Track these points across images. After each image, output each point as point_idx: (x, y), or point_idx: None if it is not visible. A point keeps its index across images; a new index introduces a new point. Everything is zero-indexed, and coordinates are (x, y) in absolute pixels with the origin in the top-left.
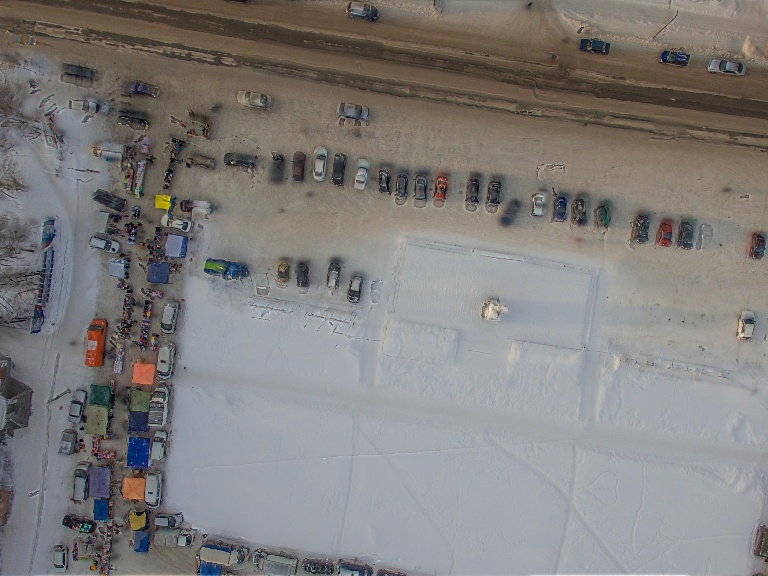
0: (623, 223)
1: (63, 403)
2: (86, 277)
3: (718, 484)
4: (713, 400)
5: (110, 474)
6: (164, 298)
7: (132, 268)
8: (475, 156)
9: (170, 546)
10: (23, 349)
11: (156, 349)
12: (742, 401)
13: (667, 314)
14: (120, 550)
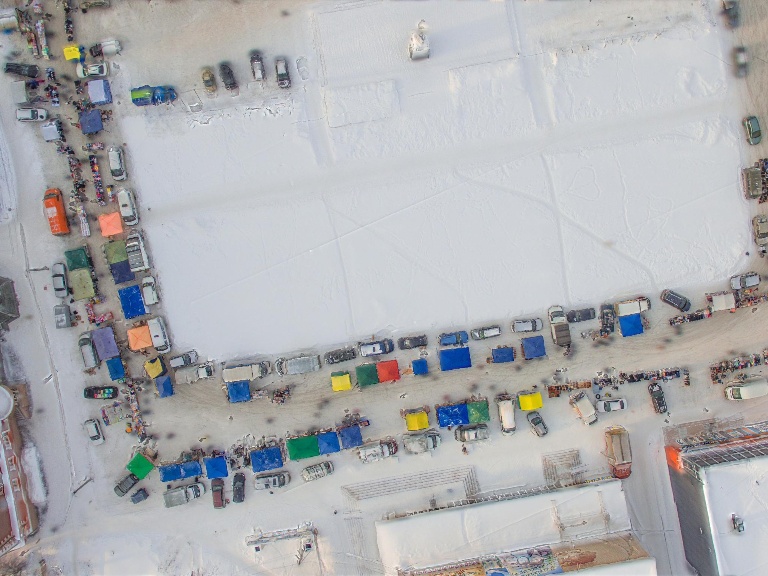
0: None
1: (46, 283)
2: (25, 154)
3: (690, 144)
4: (658, 64)
5: (112, 332)
6: (106, 148)
7: (66, 130)
8: None
9: None
10: None
11: (115, 199)
12: (685, 54)
13: None
14: (148, 406)
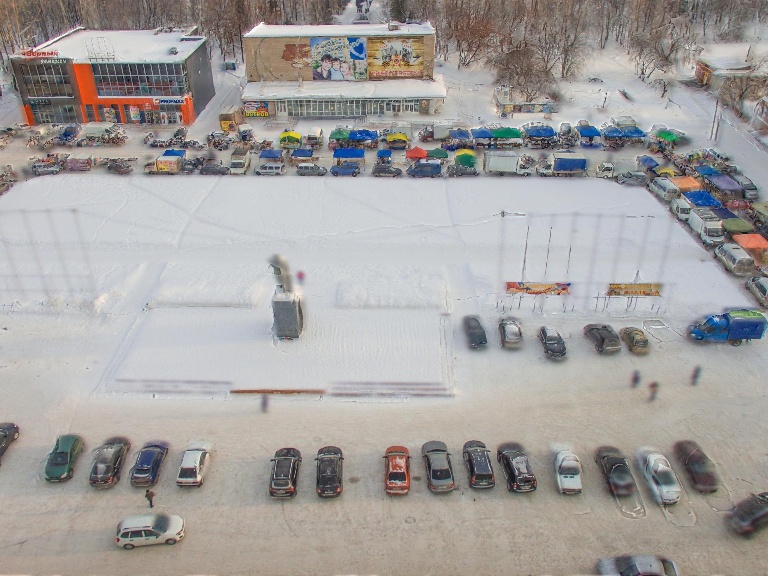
0: (18, 465)
1: None
2: None
3: None
4: None
5: None
6: None
7: None
8: (330, 547)
9: None
10: None
11: (757, 266)
12: None
13: None
14: None
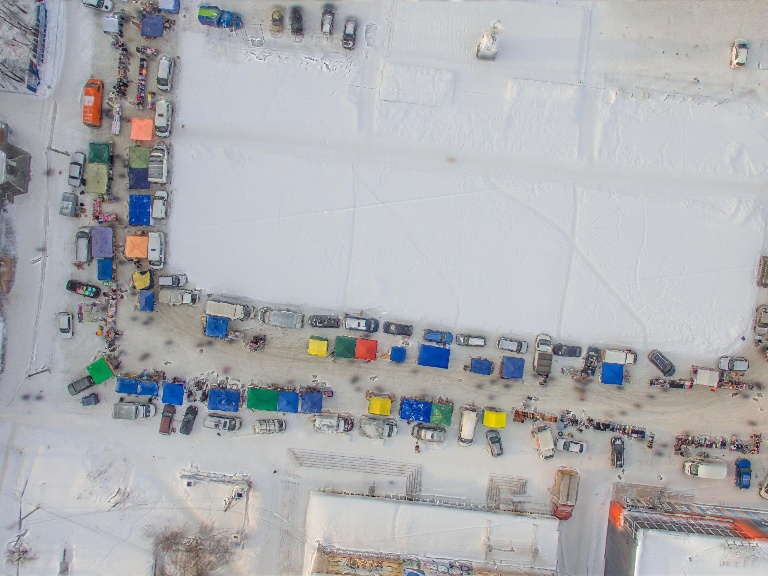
0: None
1: (62, 168)
2: (80, 38)
3: (719, 217)
4: (710, 132)
5: (112, 234)
6: (159, 55)
7: (126, 27)
8: None
9: (175, 303)
10: (20, 114)
11: (153, 107)
12: (739, 129)
13: (661, 47)
14: (125, 315)
